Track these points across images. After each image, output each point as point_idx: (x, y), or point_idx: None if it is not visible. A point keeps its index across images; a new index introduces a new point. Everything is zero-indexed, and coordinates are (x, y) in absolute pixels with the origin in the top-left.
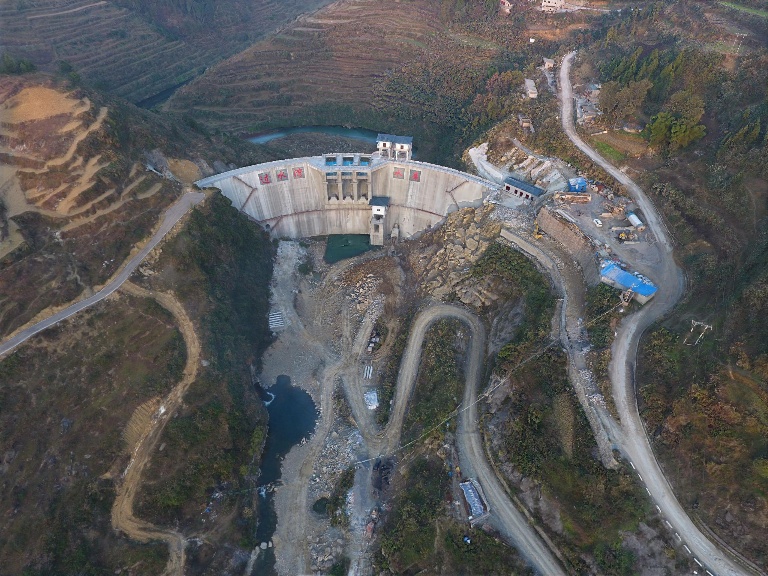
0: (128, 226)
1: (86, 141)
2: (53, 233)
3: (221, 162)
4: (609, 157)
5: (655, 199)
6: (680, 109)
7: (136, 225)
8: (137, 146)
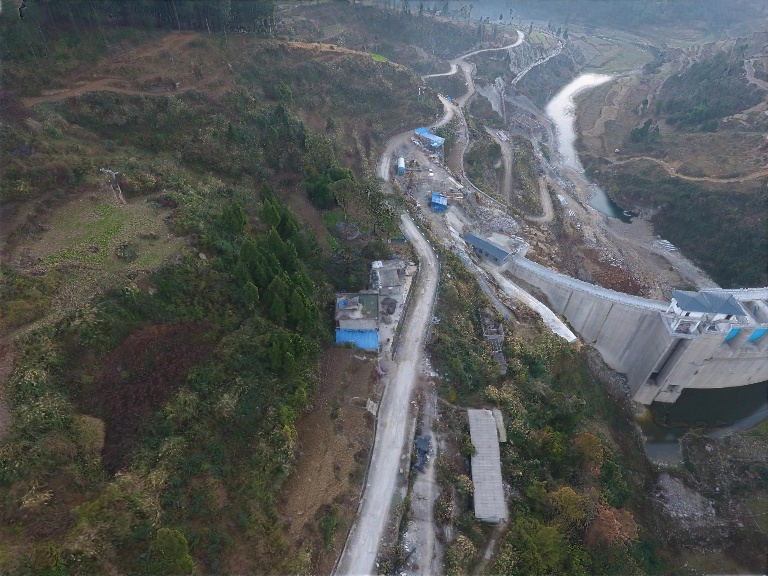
0: None
1: None
2: None
3: None
4: None
5: None
6: None
7: None
8: None
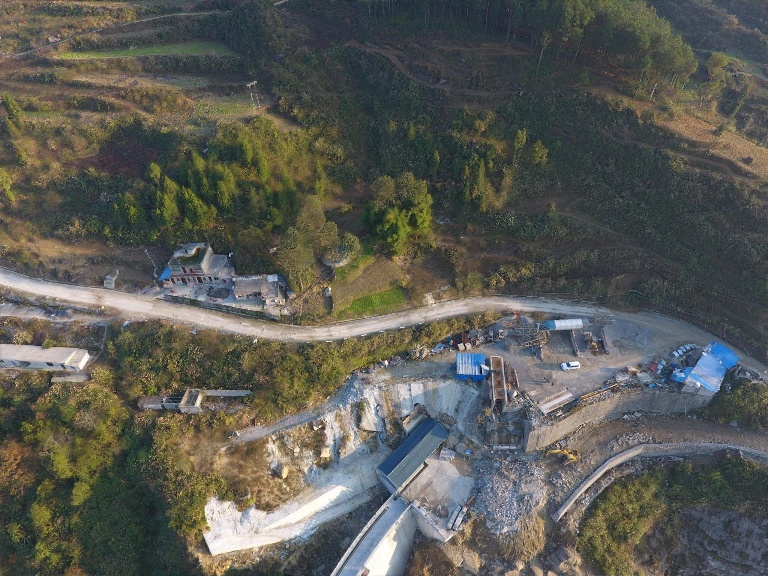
0: None
1: None
2: None
3: None
4: (395, 306)
5: (506, 291)
6: (411, 197)
7: None
8: None
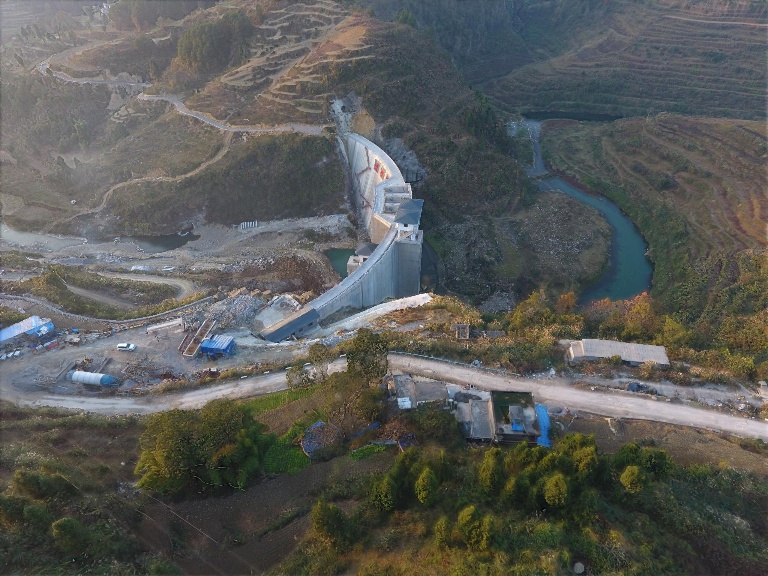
0: (271, 113)
1: (322, 64)
2: (260, 93)
3: (403, 142)
4: None
5: None
6: None
7: (275, 116)
8: (348, 86)
